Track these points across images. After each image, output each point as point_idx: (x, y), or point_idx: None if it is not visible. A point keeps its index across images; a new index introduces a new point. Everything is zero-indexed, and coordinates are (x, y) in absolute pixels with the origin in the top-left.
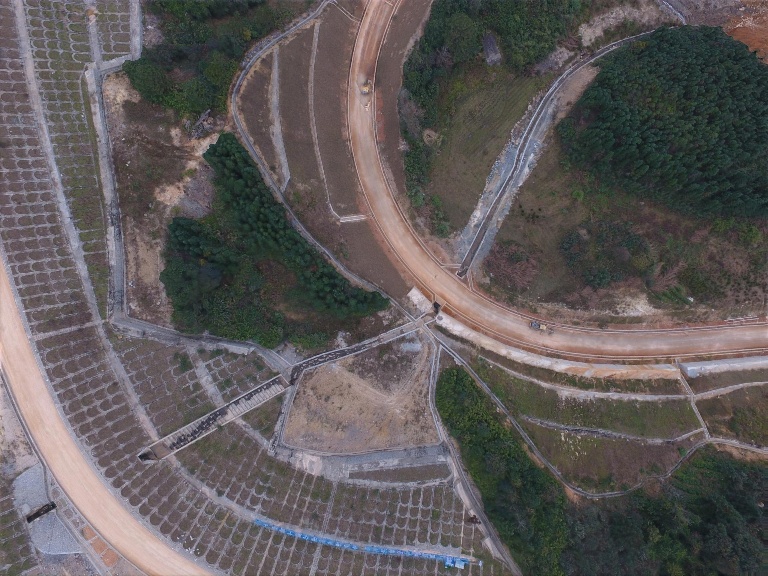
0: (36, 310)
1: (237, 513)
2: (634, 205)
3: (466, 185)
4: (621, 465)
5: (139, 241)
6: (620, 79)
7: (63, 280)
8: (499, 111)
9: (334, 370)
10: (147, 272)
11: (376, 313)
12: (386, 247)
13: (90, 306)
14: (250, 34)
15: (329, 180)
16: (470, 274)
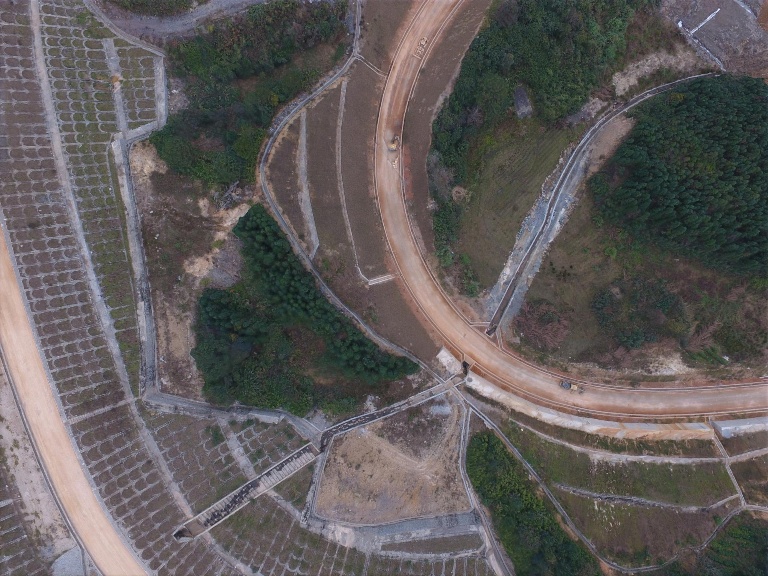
0: (70, 393)
1: None
2: (668, 262)
3: (496, 242)
4: (656, 536)
5: (169, 315)
6: (657, 136)
7: (95, 360)
8: (529, 165)
9: (364, 435)
10: (178, 346)
11: (405, 376)
12: (414, 307)
13: (122, 384)
14: (277, 99)
15: (357, 243)
16: (499, 332)
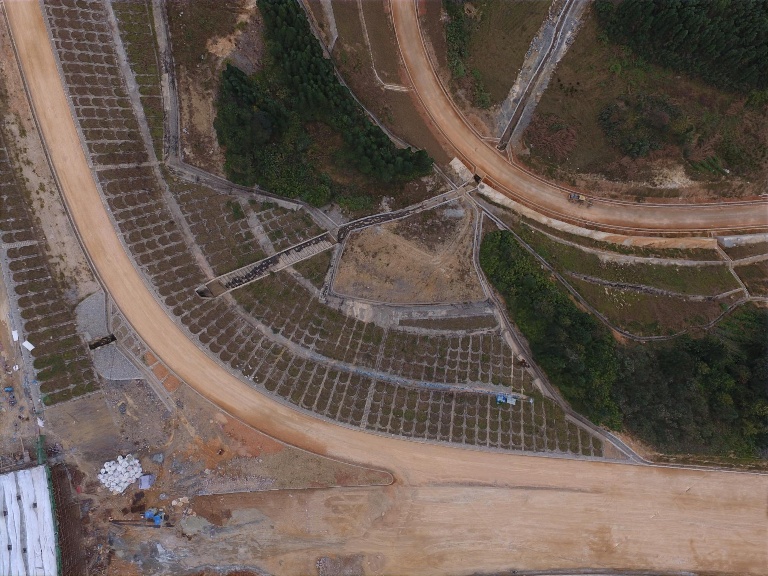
0: (96, 142)
1: (292, 350)
2: (670, 79)
3: (505, 60)
4: (665, 315)
5: (192, 90)
6: None
7: (121, 119)
8: None
9: (379, 233)
10: (200, 121)
11: (420, 179)
12: (427, 119)
13: (146, 147)
14: None
15: (373, 47)
16: (509, 148)
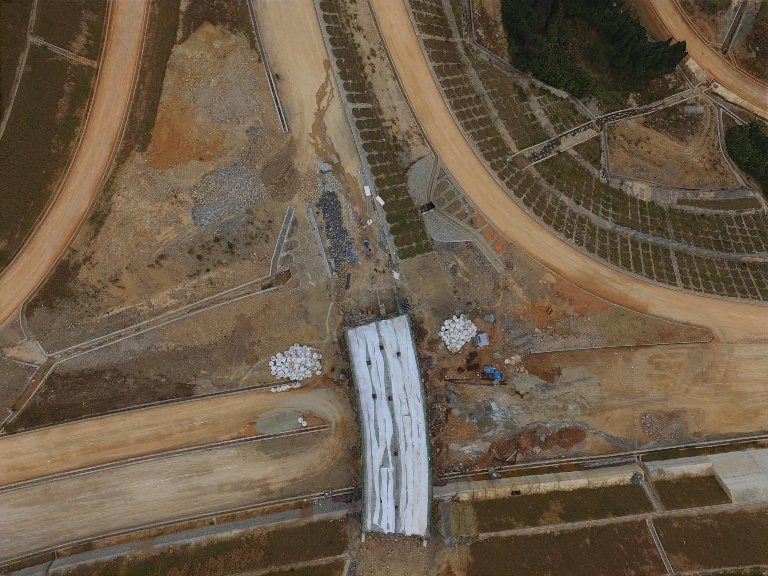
0: (418, 12)
1: (594, 221)
2: None
3: None
4: None
5: None
6: None
7: None
8: None
9: (630, 126)
10: (487, 5)
11: (663, 76)
12: (659, 23)
13: (450, 24)
14: None
15: None
16: (732, 53)
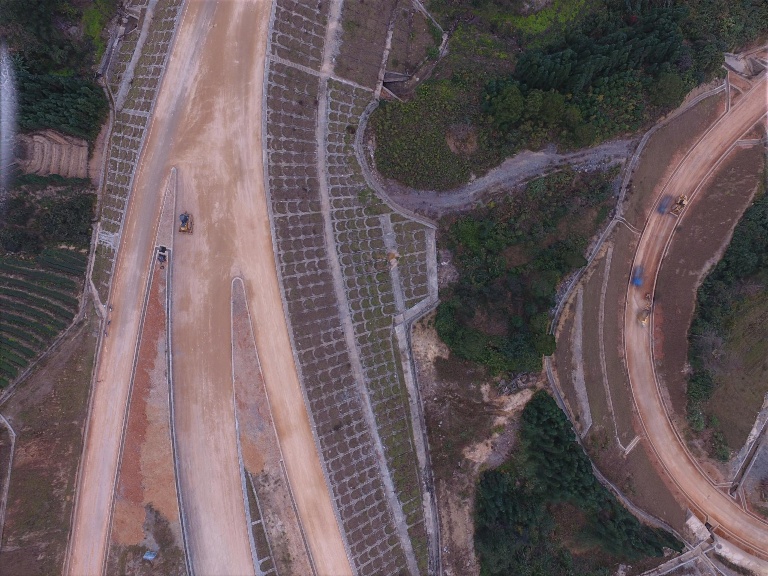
0: None
1: None
2: None
3: (744, 402)
4: None
5: (450, 503)
6: None
7: (392, 560)
8: None
9: None
10: (458, 534)
11: None
12: (660, 468)
13: None
14: None
15: (616, 412)
16: (743, 493)
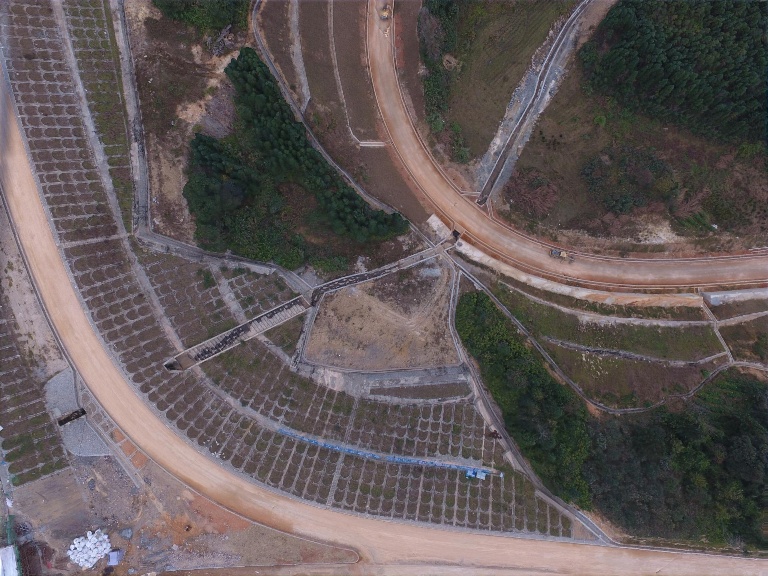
0: (64, 219)
1: (261, 423)
2: (657, 131)
3: (486, 112)
4: (643, 384)
5: (162, 158)
6: None
7: (89, 192)
8: (520, 36)
9: (354, 294)
10: (170, 189)
11: (396, 238)
12: (405, 174)
13: (115, 219)
14: None
15: (349, 104)
16: (490, 202)
